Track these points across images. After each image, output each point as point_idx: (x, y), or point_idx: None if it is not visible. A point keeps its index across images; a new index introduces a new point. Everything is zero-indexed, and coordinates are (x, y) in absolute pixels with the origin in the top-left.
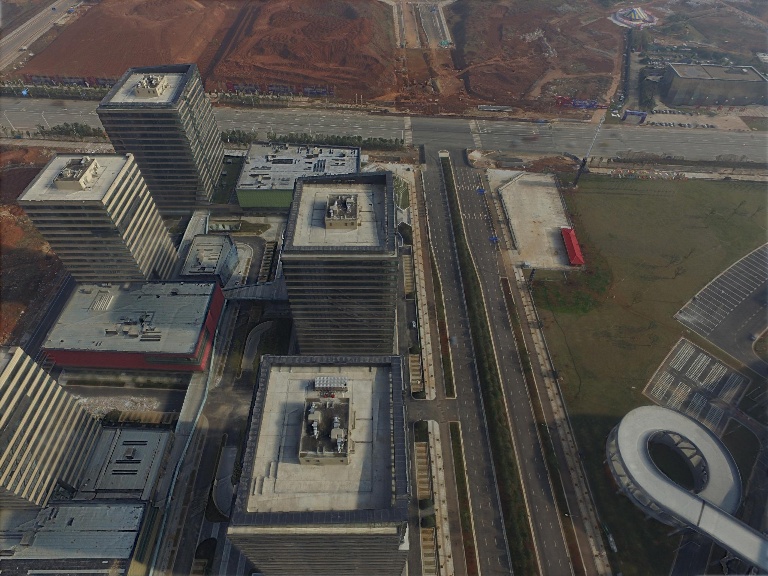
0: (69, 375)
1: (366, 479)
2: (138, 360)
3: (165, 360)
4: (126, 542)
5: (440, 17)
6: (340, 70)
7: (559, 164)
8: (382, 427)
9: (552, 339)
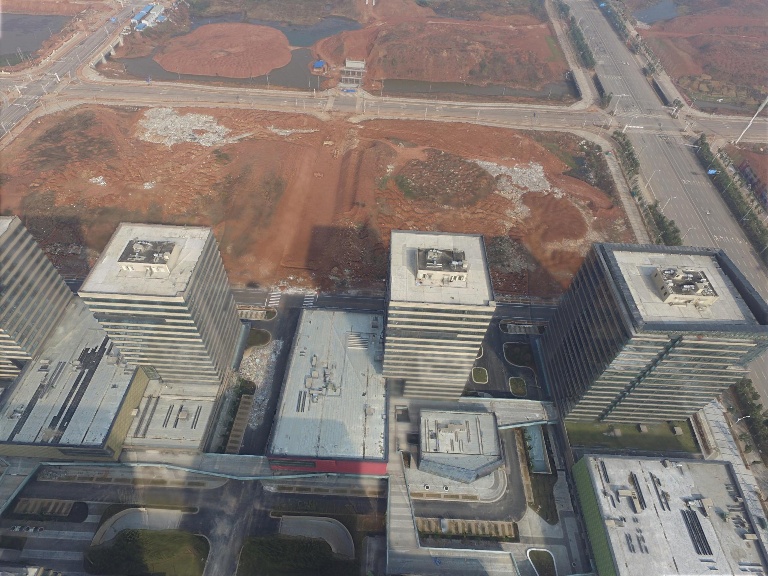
0: None
1: None
2: None
3: None
4: (75, 437)
5: None
6: None
7: None
8: None
9: None
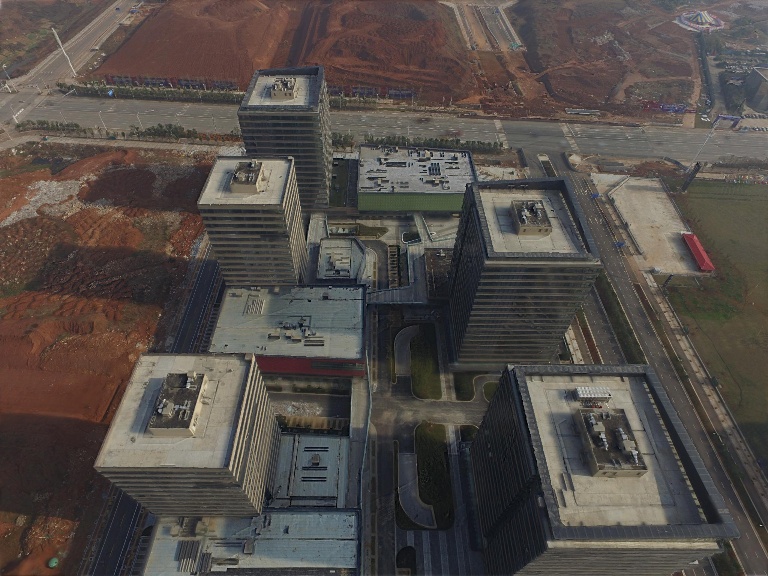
0: None
1: (665, 492)
2: (302, 365)
3: (329, 365)
4: (348, 551)
5: (504, 19)
6: (421, 72)
7: (662, 169)
8: (658, 439)
9: (701, 346)
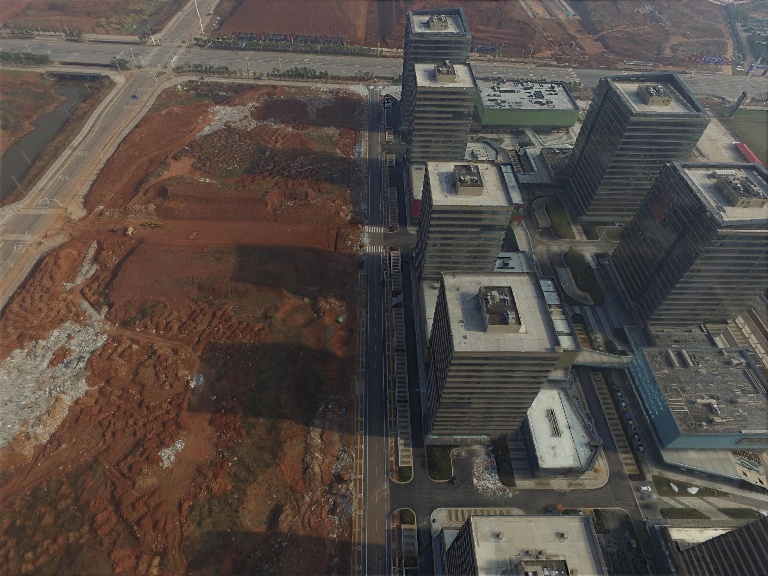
0: (415, 227)
1: None
2: None
3: None
4: (552, 297)
5: None
6: (499, 32)
7: (710, 102)
8: None
9: None
